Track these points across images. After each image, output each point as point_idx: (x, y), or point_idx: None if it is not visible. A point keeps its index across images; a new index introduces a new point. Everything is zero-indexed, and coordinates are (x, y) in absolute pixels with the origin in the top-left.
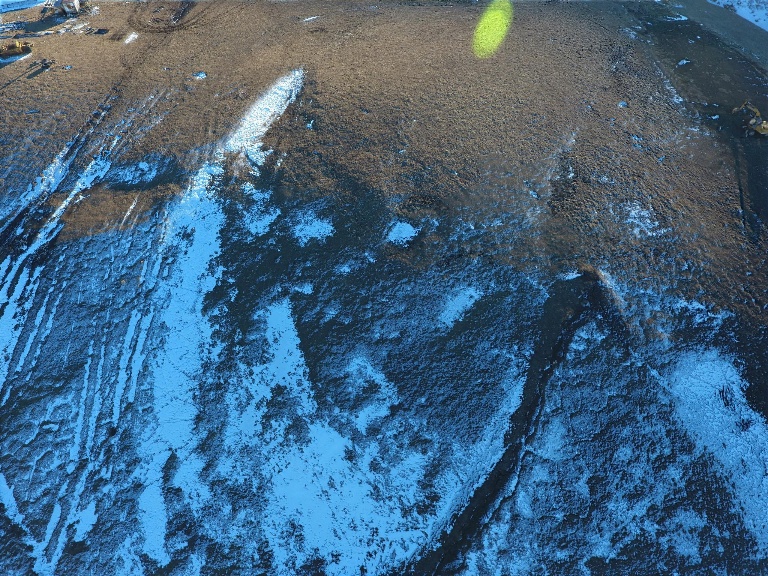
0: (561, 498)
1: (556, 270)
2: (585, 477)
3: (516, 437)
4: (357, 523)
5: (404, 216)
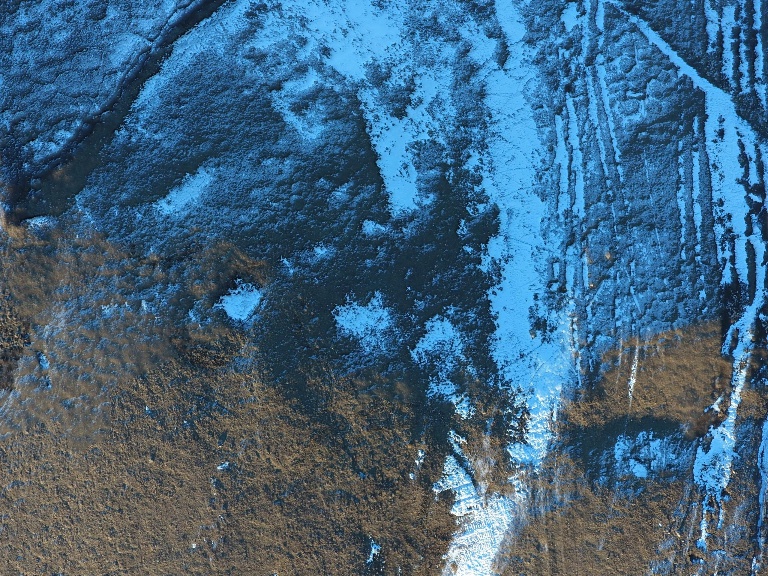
0: (134, 6)
1: (54, 231)
2: (106, 20)
3: (159, 53)
4: (322, 3)
5: (234, 330)
